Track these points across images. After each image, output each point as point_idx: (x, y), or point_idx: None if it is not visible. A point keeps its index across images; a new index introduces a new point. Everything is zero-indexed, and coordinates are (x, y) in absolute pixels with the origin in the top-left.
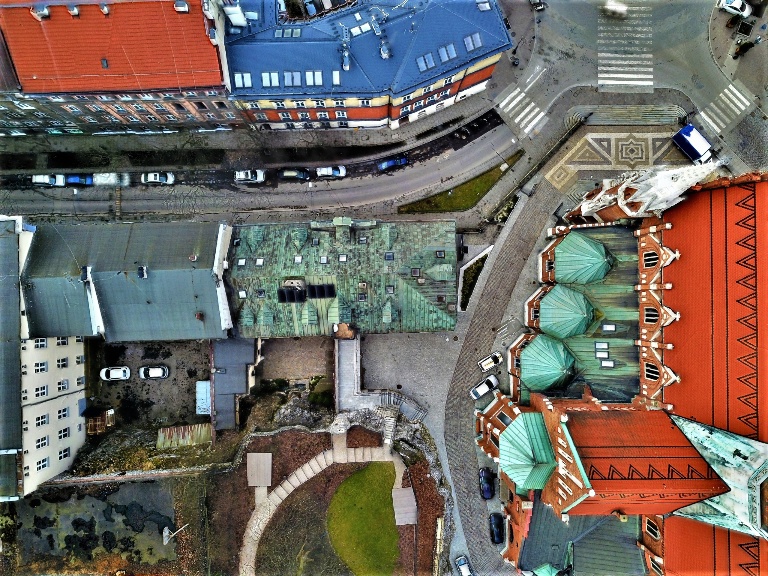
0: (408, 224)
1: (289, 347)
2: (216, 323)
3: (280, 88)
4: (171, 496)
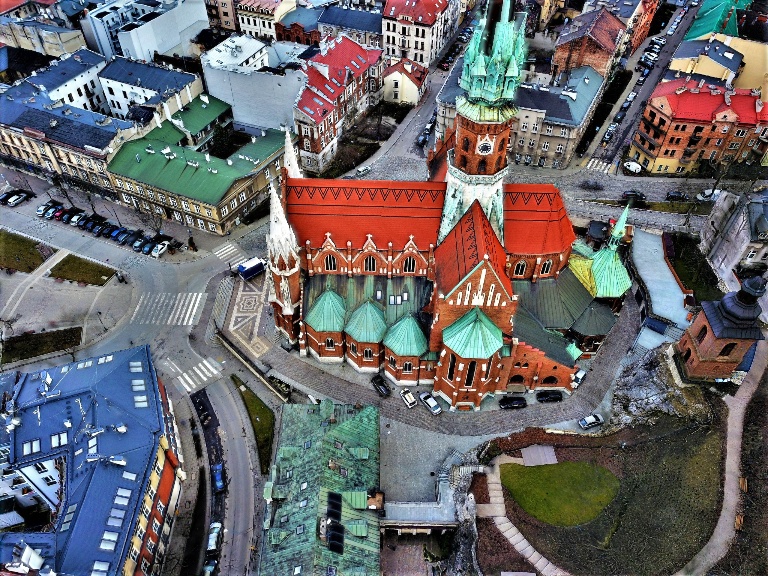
0: (280, 440)
1: None
2: None
3: (121, 533)
4: None
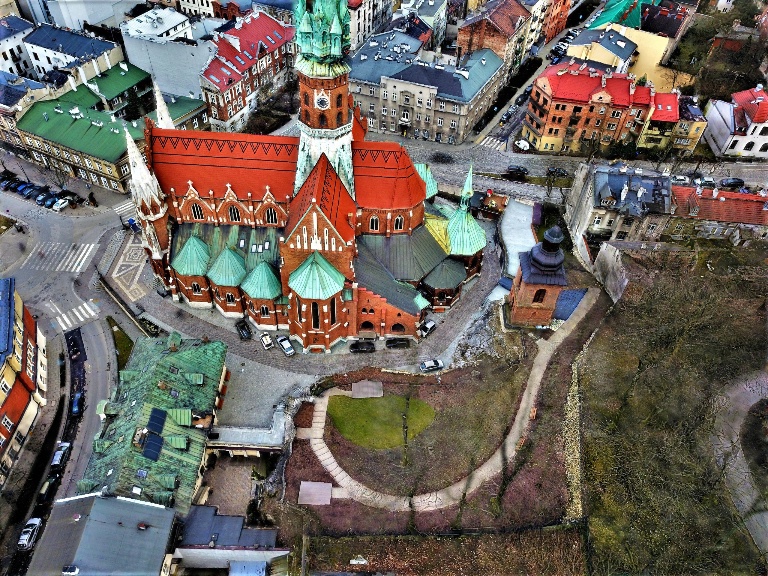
0: (127, 368)
1: (217, 500)
2: (156, 514)
3: None
4: (327, 574)
